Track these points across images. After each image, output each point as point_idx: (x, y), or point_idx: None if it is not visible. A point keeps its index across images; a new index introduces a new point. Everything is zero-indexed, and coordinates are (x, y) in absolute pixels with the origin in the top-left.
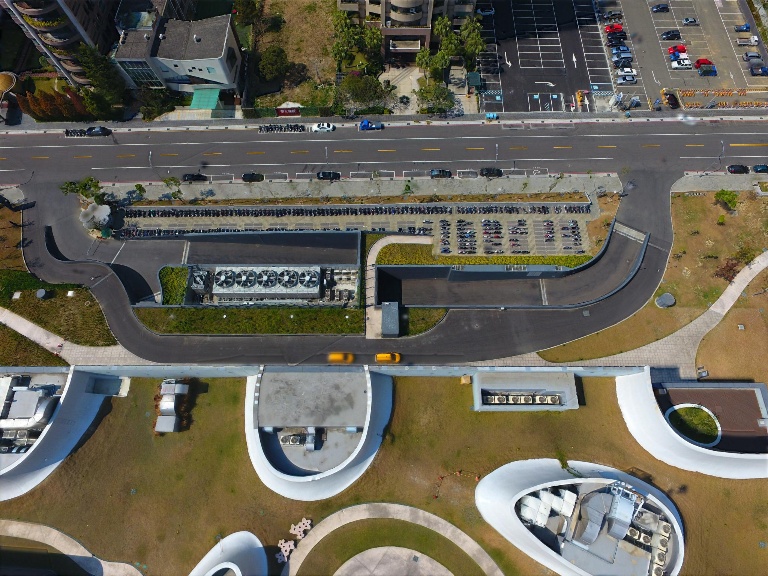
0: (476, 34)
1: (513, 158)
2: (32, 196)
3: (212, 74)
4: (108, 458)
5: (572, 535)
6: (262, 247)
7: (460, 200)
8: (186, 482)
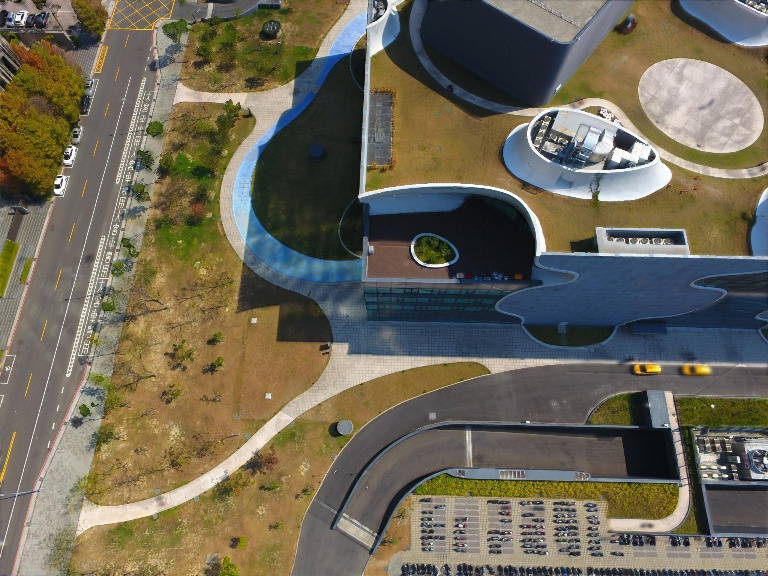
0: None
1: None
2: None
3: None
4: None
5: None
6: None
7: None
8: None
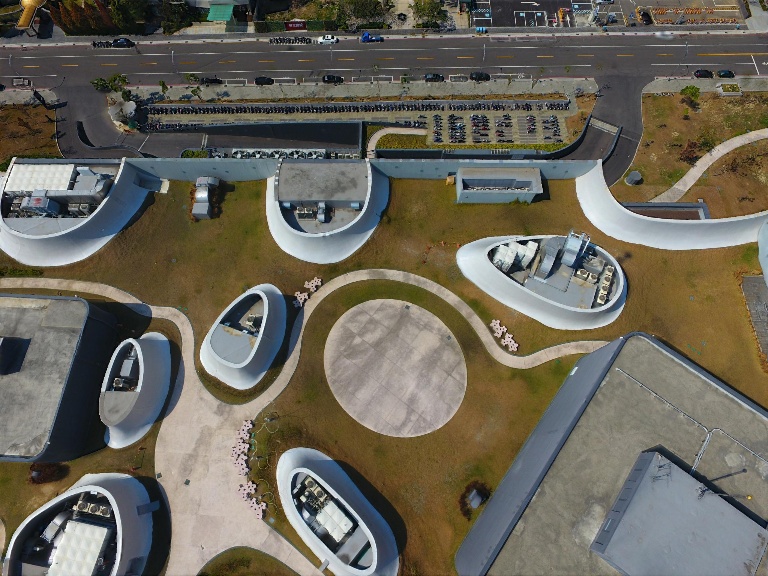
0: None
1: (500, 65)
2: (64, 97)
3: None
4: (153, 237)
5: (534, 273)
6: (273, 140)
7: (451, 98)
8: (218, 254)
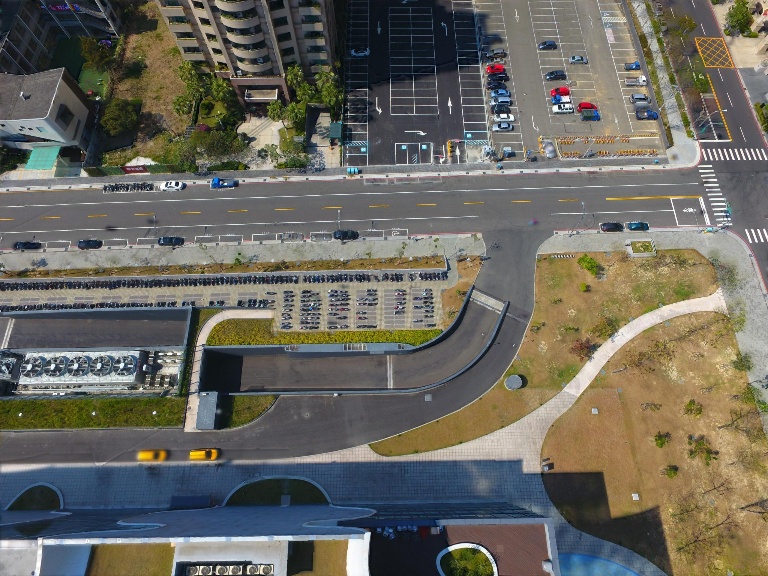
0: (330, 84)
1: (372, 218)
2: None
3: (44, 133)
4: None
5: None
6: (94, 322)
7: (307, 268)
8: None
